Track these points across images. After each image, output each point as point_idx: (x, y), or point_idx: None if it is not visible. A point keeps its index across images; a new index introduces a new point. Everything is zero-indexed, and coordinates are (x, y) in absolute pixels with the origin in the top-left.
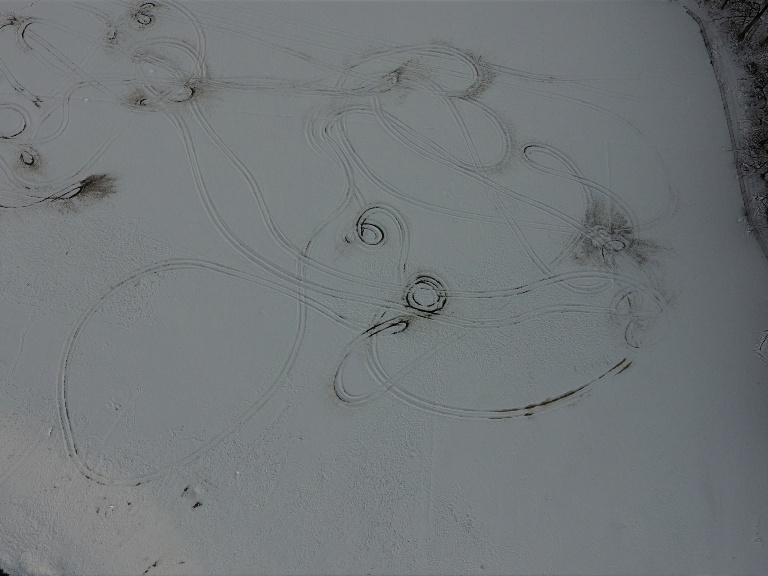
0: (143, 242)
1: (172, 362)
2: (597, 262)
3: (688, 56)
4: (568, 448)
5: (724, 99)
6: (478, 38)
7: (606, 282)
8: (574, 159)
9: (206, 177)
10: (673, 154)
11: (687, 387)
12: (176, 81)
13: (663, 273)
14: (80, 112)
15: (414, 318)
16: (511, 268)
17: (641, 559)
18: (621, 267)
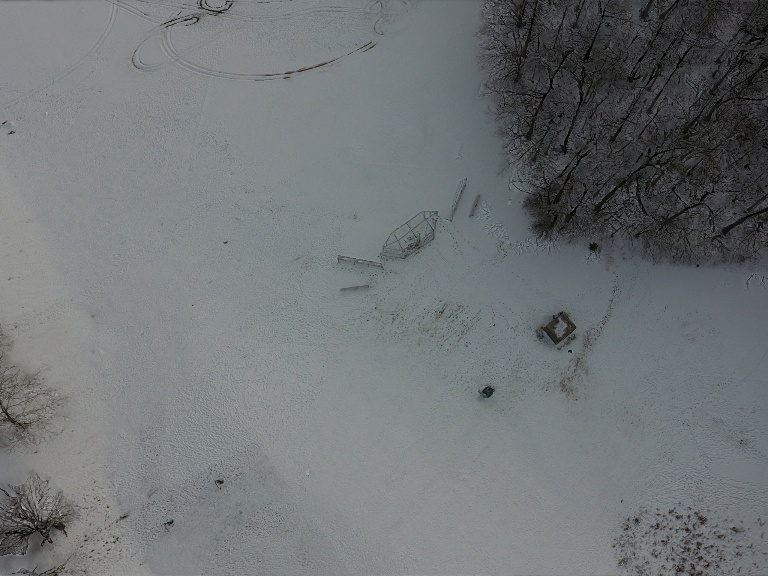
0: None
1: (5, 42)
2: None
3: None
4: (315, 99)
5: None
6: None
7: None
8: None
9: None
10: None
11: (419, 60)
12: None
13: None
14: None
15: (204, 15)
16: None
17: (361, 170)
18: None
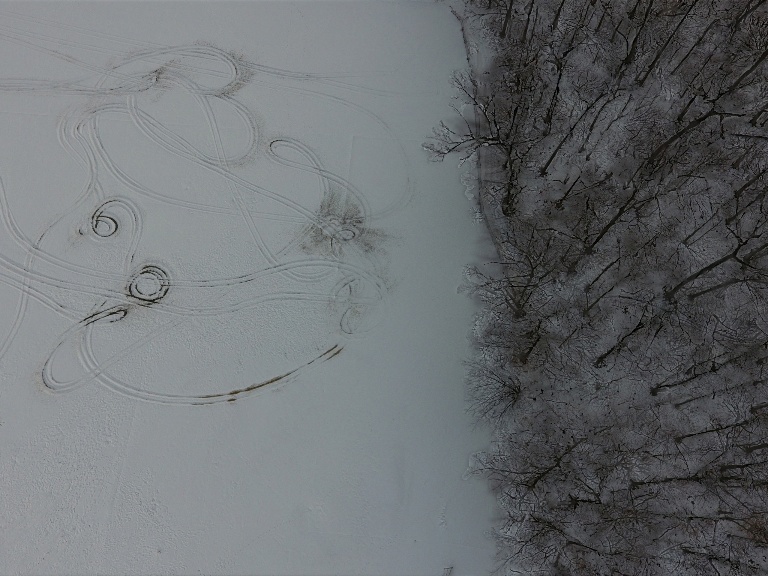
0: None
1: None
2: (324, 251)
3: (446, 53)
4: (266, 433)
5: (475, 93)
6: (242, 39)
7: (330, 270)
8: (317, 152)
9: None
10: (416, 146)
11: (394, 372)
12: None
13: (388, 261)
14: None
15: (133, 307)
16: (238, 258)
17: (321, 543)
18: (347, 256)
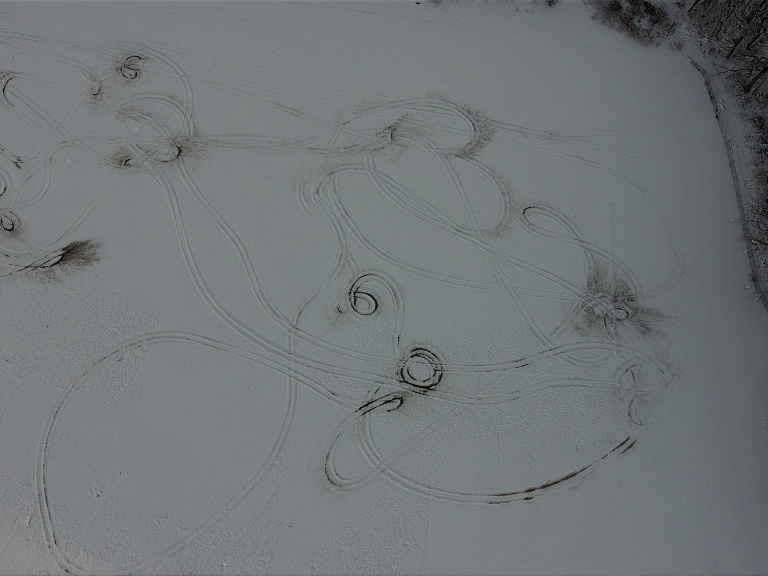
0: (127, 314)
1: (156, 444)
2: (599, 332)
3: (693, 110)
4: (570, 535)
5: (730, 156)
6: (475, 92)
7: (609, 354)
8: (575, 221)
9: (193, 243)
10: (678, 215)
11: (694, 468)
12: (162, 140)
13: (668, 344)
14: (62, 173)
15: (409, 394)
16: (510, 339)
17: None
18: (624, 338)
